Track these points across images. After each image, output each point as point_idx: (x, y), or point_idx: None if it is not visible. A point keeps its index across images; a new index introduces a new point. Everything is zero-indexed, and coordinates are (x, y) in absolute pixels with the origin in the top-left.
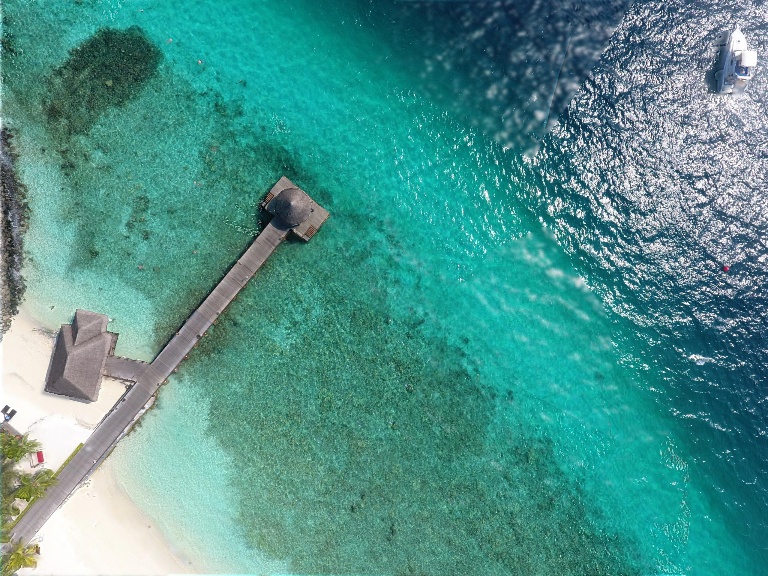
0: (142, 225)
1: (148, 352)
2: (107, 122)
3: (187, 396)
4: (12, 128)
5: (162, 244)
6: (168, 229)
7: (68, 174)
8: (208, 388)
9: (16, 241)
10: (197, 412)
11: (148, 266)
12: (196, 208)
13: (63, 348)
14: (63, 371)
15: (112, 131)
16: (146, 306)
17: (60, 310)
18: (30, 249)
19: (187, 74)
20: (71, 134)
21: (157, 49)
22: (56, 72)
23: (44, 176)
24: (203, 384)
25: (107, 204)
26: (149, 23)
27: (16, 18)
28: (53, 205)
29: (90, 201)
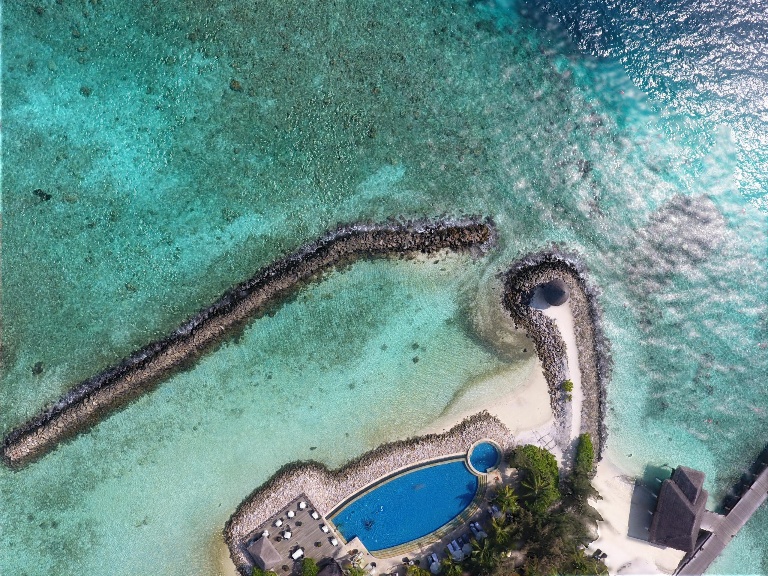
0: (707, 380)
1: (711, 501)
2: (680, 282)
3: (743, 544)
4: (600, 285)
5: (725, 399)
6: (730, 385)
7: (645, 330)
8: (762, 538)
9: (602, 392)
10: (751, 560)
11: (712, 420)
12: (754, 367)
13: (682, 506)
14: (690, 530)
15: (683, 291)
16: (710, 457)
17: (636, 458)
18: (611, 399)
19: (750, 240)
20: (650, 293)
21: (726, 216)
22: (638, 234)
23: (624, 331)
24: (758, 534)
25: (677, 359)
26: (718, 192)
27: (604, 182)
28: (631, 358)
29: (662, 356)
